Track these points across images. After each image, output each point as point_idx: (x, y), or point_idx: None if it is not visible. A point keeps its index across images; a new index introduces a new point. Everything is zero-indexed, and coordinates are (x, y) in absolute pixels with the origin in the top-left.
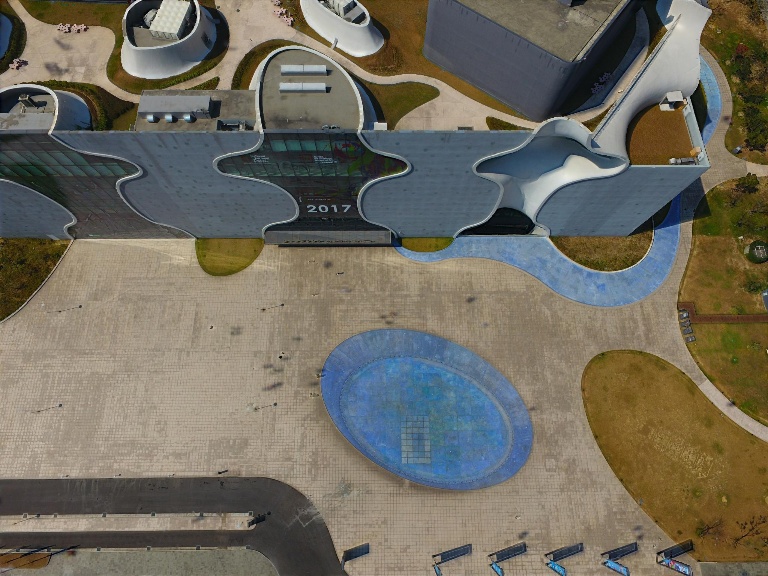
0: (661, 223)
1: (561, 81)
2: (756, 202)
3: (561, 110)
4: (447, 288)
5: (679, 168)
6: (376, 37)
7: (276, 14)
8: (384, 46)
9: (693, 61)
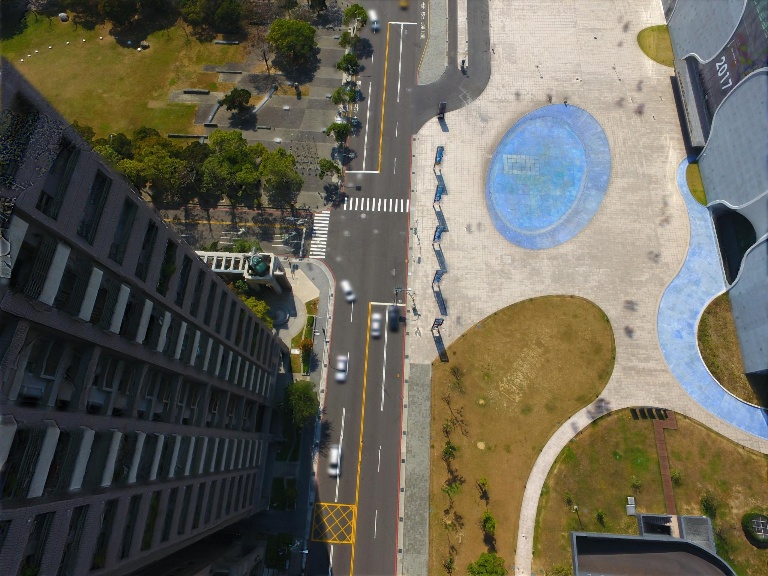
0: None
1: None
2: None
3: None
4: (654, 196)
5: None
6: None
7: None
8: None
9: None
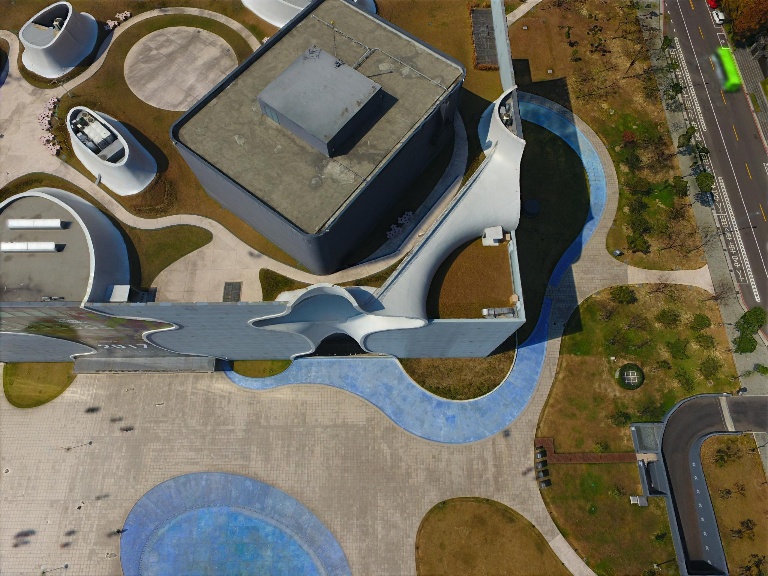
0: (526, 340)
1: (313, 248)
2: (634, 315)
3: (349, 259)
4: (277, 421)
5: (490, 322)
6: (141, 174)
7: (41, 141)
8: (153, 183)
9: (512, 194)
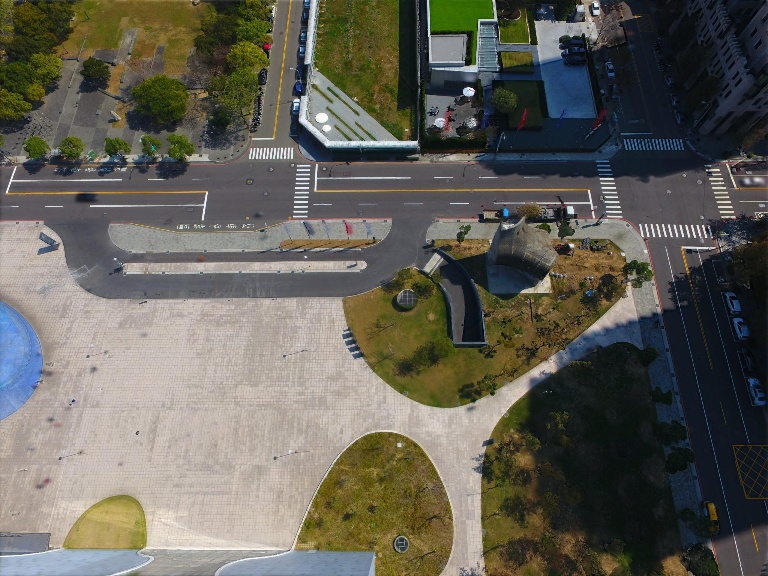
0: None
1: None
2: None
3: None
4: None
5: None
6: None
7: None
8: None
9: None
